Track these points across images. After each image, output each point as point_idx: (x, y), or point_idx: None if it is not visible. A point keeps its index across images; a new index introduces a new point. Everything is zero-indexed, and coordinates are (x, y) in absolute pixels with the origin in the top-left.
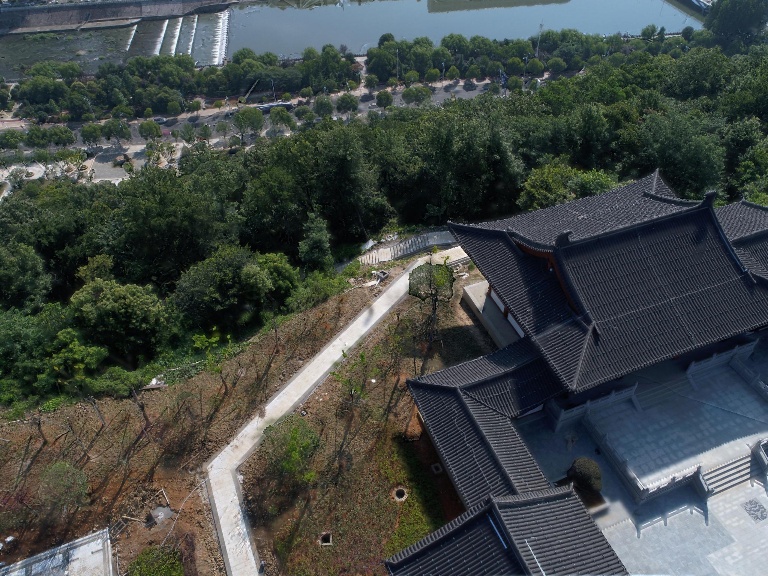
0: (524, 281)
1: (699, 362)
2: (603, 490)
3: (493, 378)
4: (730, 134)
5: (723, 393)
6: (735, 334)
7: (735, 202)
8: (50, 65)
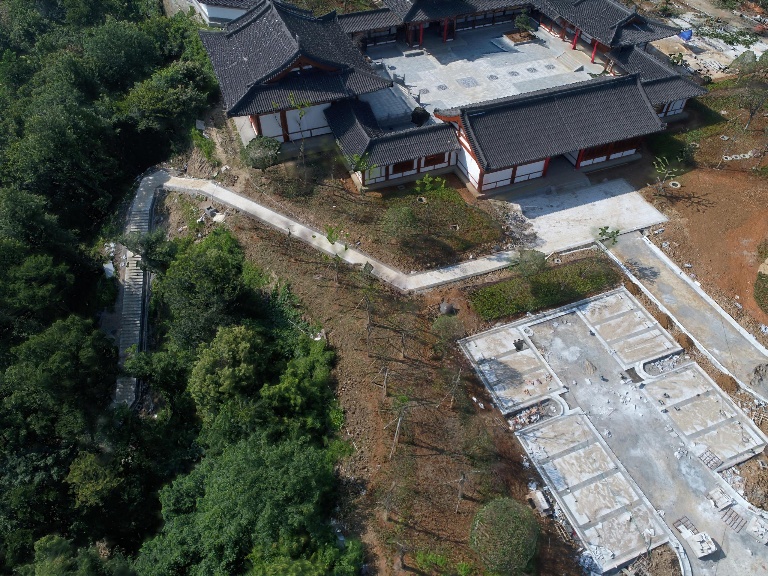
0: (300, 89)
1: None
2: None
3: None
4: None
5: None
6: None
7: (183, 55)
8: None
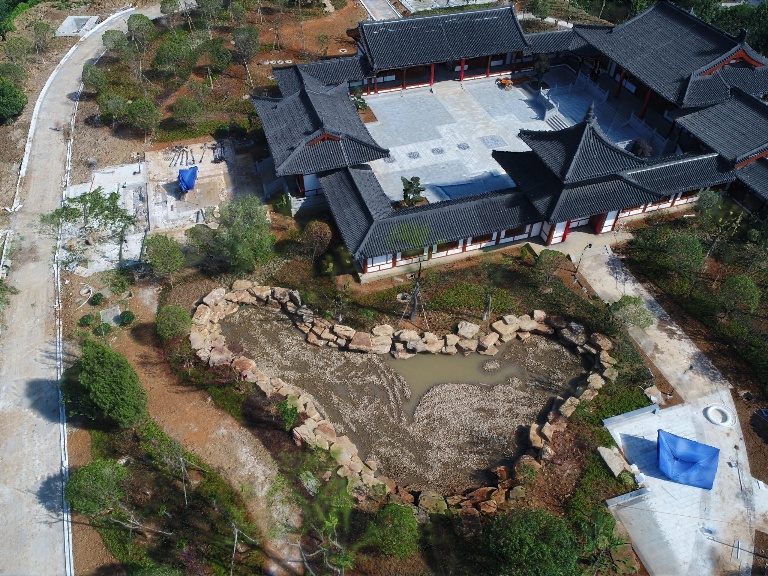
0: None
1: (636, 116)
2: None
3: None
4: None
5: (620, 135)
6: (639, 78)
7: None
8: None
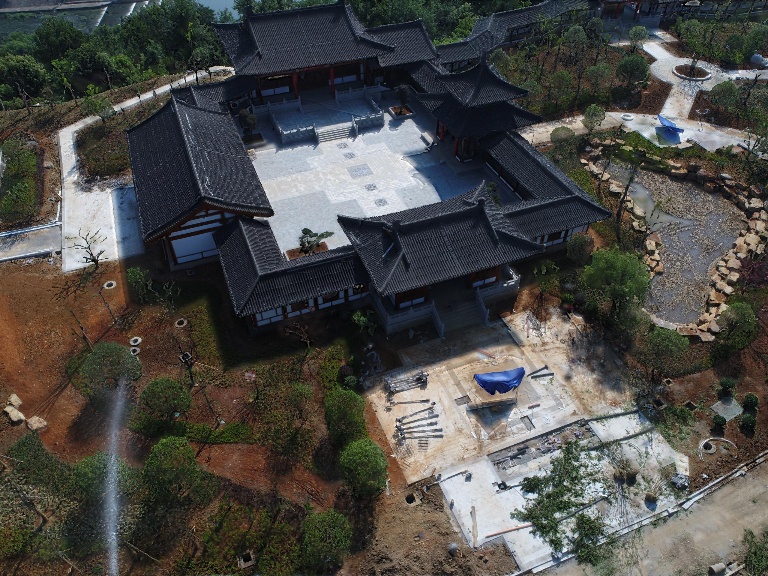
0: (239, 42)
1: (341, 92)
2: (268, 140)
3: (213, 85)
4: (455, 16)
5: (353, 108)
6: (340, 61)
7: None
8: (25, 33)
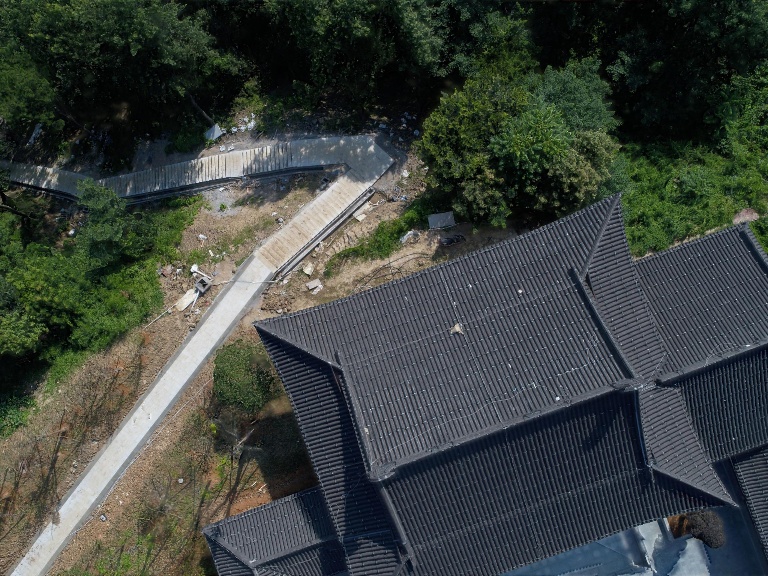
0: (345, 450)
1: None
2: None
3: (298, 550)
4: None
5: None
6: None
7: None
8: None
